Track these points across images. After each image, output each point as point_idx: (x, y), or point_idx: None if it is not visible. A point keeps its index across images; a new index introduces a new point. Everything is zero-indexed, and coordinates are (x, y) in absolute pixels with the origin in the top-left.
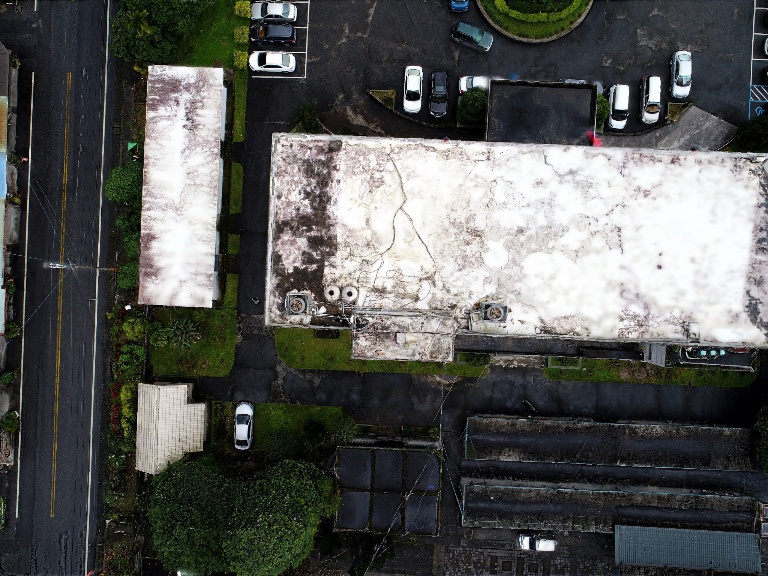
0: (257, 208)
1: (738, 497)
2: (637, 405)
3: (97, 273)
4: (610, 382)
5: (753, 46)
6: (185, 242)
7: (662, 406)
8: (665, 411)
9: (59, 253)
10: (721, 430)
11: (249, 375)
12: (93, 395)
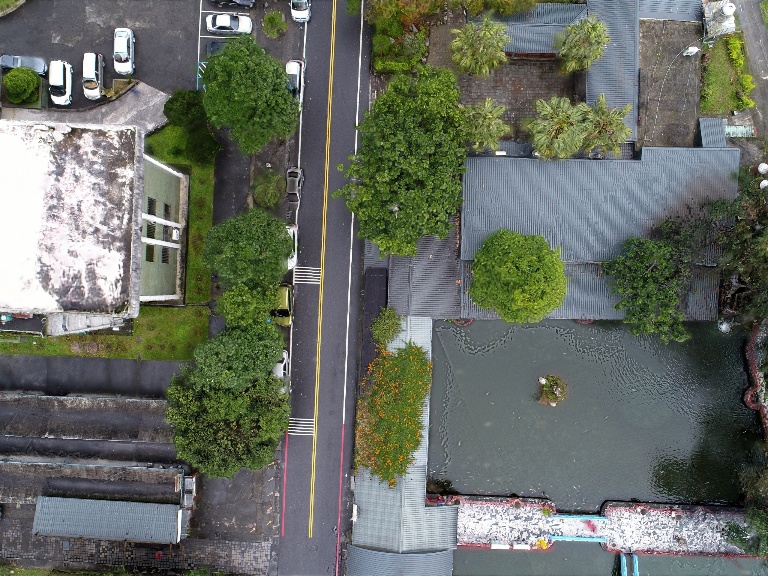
0: None
1: (165, 469)
2: (87, 379)
3: None
4: (61, 356)
5: (200, 23)
6: None
7: (112, 380)
8: (115, 385)
9: None
10: (148, 402)
11: None
12: None
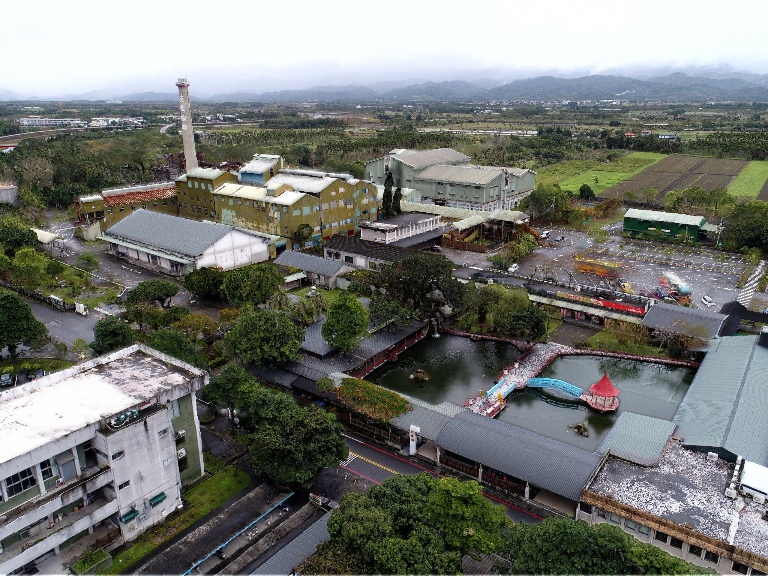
0: None
1: (299, 510)
2: None
3: None
4: (151, 552)
5: None
6: None
7: None
8: None
9: None
10: (246, 497)
11: None
12: None
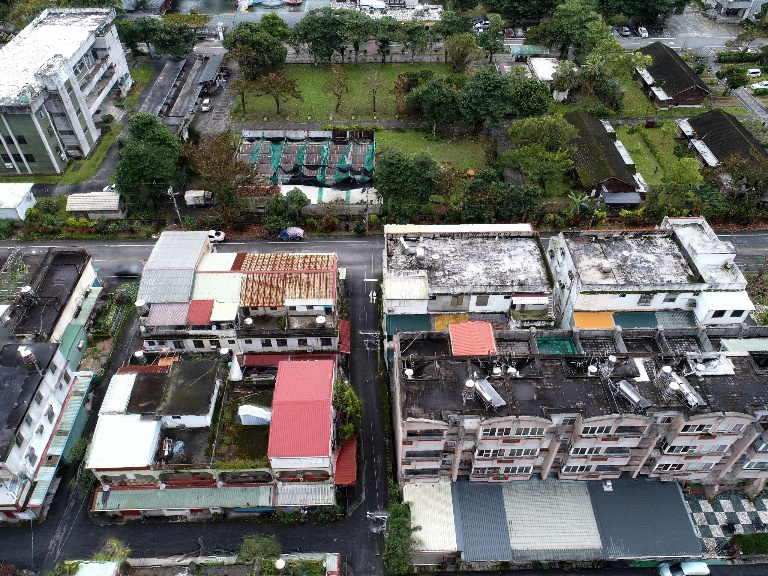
0: None
1: None
2: None
3: None
4: None
5: None
6: None
7: None
8: None
9: None
10: (166, 66)
11: (88, 191)
12: None
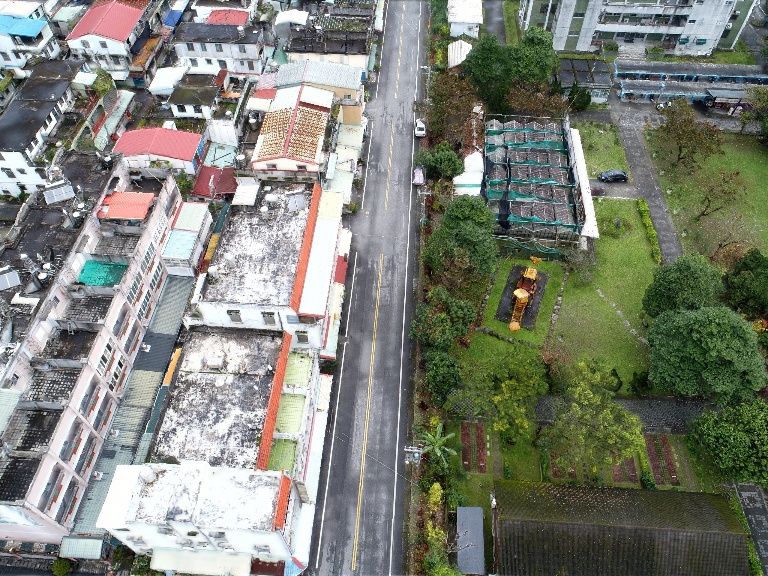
0: (493, 18)
1: None
2: None
3: (419, 31)
4: None
5: None
6: (468, 8)
7: None
8: None
9: (401, 25)
10: (745, 65)
11: None
12: (418, 62)
